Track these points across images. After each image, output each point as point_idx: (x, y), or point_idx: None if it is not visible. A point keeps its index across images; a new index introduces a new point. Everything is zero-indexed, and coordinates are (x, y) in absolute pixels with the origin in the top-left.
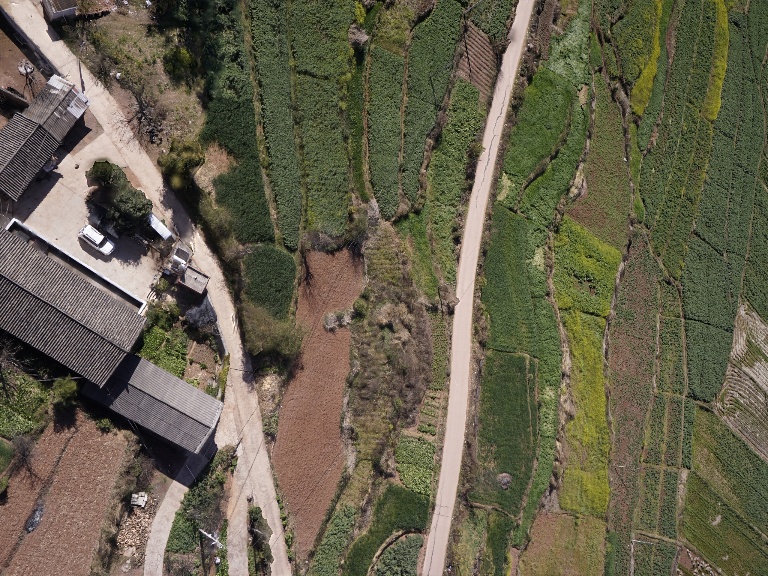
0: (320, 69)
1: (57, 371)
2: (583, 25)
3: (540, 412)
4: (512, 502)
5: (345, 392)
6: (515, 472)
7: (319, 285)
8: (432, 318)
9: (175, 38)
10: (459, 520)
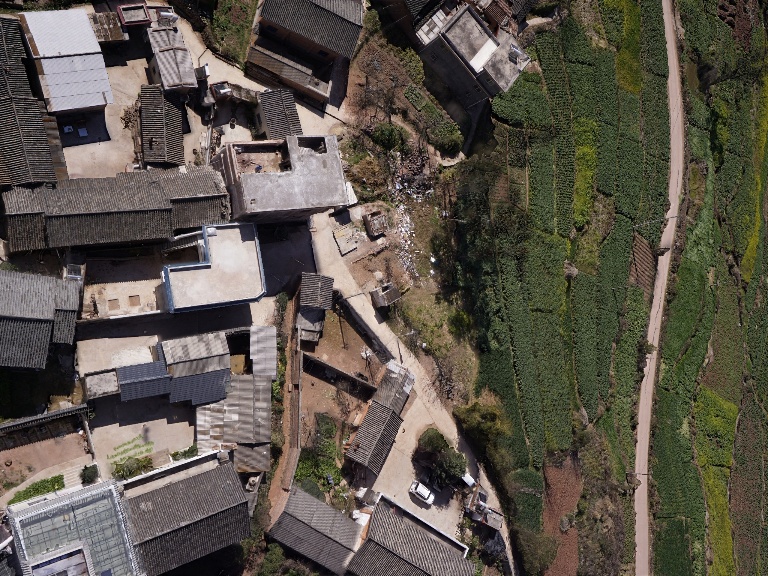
0: (546, 304)
1: None
2: (709, 213)
3: (692, 564)
4: None
5: None
6: None
7: (554, 493)
8: (623, 501)
9: (454, 301)
10: None
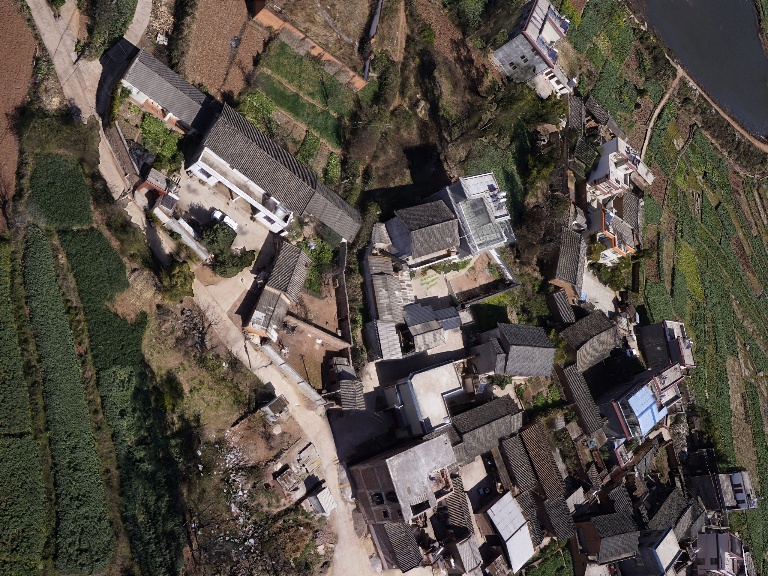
0: None
1: None
2: None
3: None
4: None
5: None
6: None
7: None
8: None
9: (176, 421)
10: None
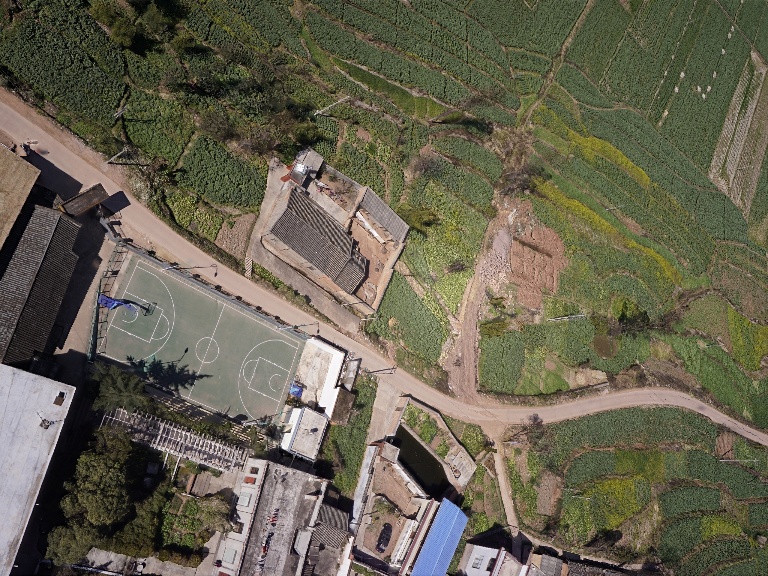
0: None
1: None
2: (675, 341)
3: None
4: None
5: None
6: None
7: None
8: None
9: None
10: None
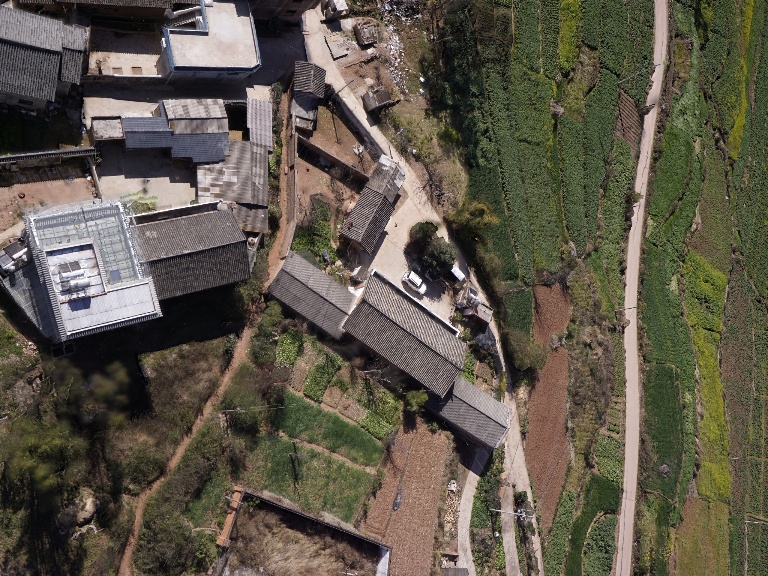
0: (533, 137)
1: (408, 386)
2: (694, 86)
3: (683, 413)
4: (670, 488)
5: (567, 399)
6: (671, 463)
7: (544, 313)
8: (612, 337)
9: (443, 119)
10: (640, 503)
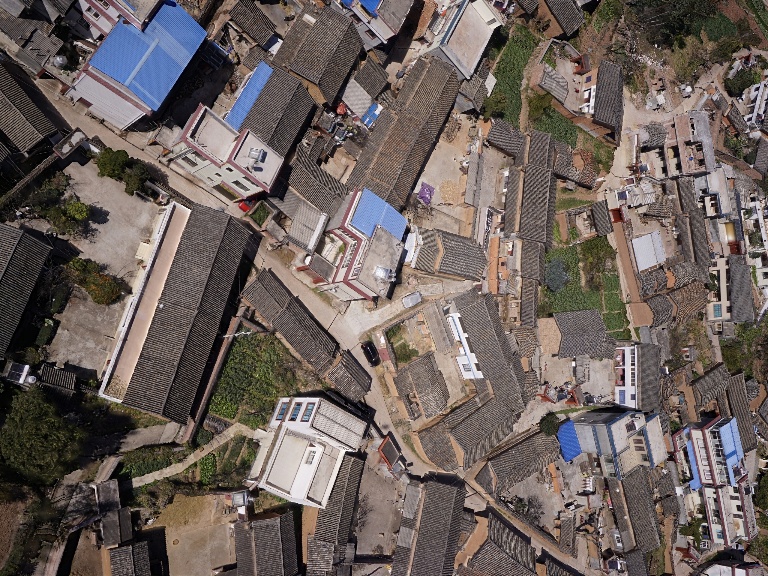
0: None
1: None
2: None
3: None
4: None
5: (740, 7)
6: None
7: (716, 3)
8: None
9: None
10: None
